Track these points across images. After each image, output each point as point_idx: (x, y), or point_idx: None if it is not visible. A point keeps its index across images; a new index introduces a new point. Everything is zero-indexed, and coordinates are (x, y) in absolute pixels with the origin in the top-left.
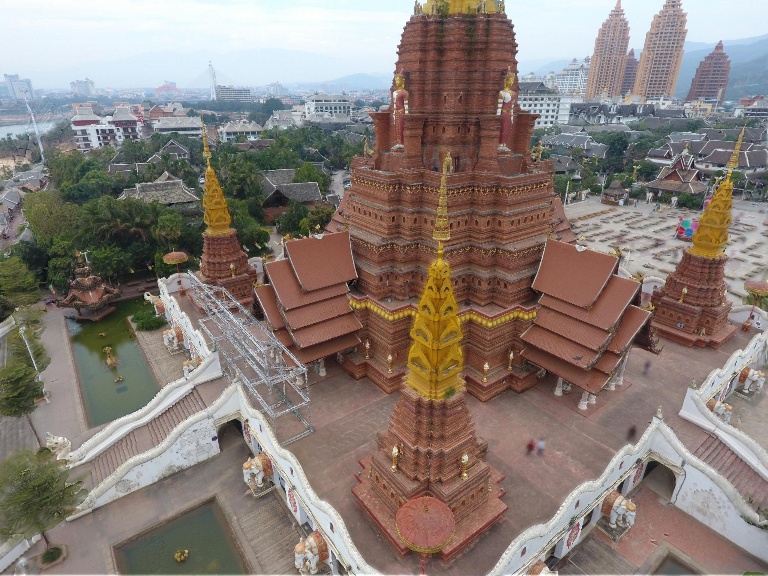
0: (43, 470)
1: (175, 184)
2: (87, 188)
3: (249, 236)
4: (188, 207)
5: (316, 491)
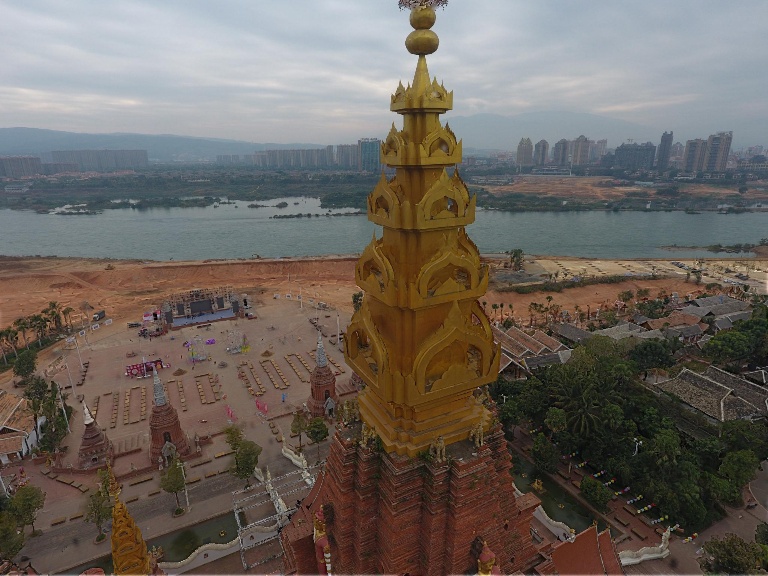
0: (242, 455)
1: (720, 389)
2: (655, 349)
3: (650, 491)
4: (706, 420)
5: (194, 572)
